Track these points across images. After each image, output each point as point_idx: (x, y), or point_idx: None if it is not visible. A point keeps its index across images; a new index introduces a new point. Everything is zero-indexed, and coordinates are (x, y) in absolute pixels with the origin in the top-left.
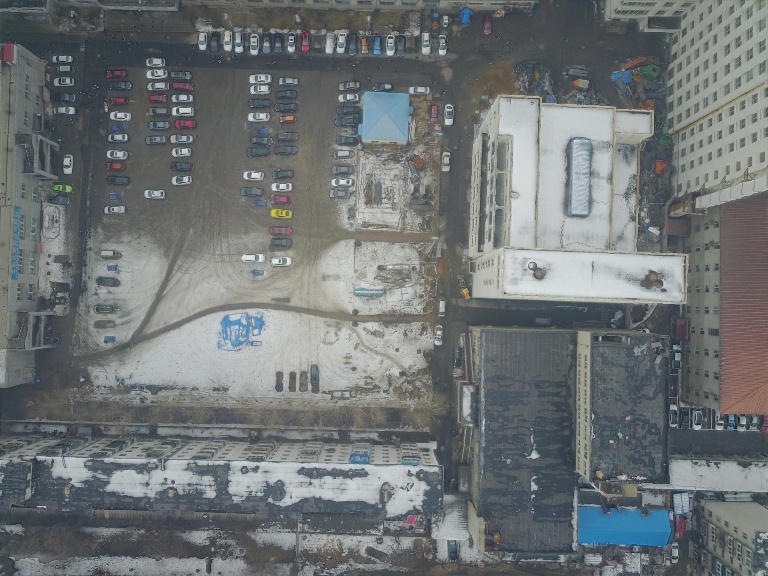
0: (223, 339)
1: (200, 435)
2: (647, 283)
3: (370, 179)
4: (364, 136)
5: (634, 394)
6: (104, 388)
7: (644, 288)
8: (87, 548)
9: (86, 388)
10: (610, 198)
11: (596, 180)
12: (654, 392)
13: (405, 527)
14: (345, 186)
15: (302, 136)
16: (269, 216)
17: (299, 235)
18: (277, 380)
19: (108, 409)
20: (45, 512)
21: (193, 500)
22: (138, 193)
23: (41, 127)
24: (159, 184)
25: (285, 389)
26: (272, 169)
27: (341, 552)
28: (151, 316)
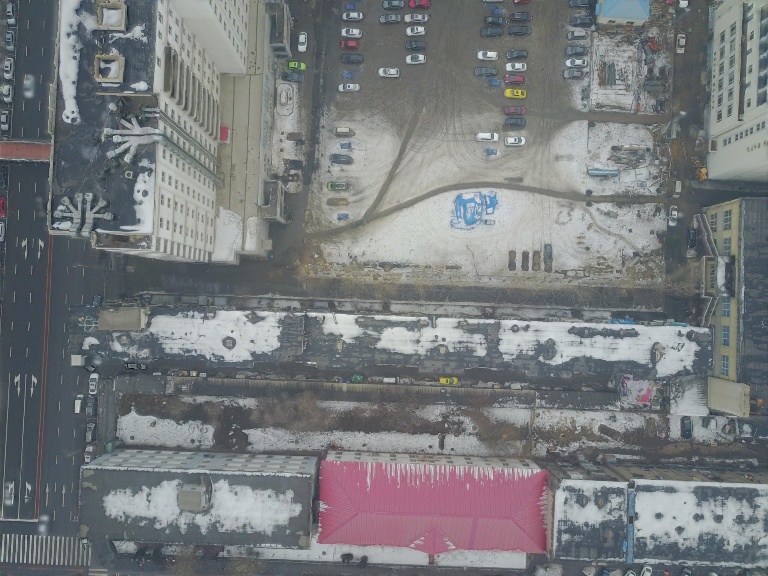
0: (456, 217)
1: (433, 312)
2: None
3: (604, 60)
4: (606, 14)
5: None
6: (337, 265)
7: None
8: (320, 423)
9: (320, 264)
10: None
11: None
12: None
13: (639, 405)
14: (580, 67)
15: (535, 17)
16: (502, 96)
17: (532, 115)
18: (510, 259)
19: (341, 286)
20: (283, 384)
21: (463, 358)
22: (371, 72)
23: (282, 1)
24: (392, 63)
25: (518, 268)
26: (505, 50)
27: (574, 430)
28: (384, 194)
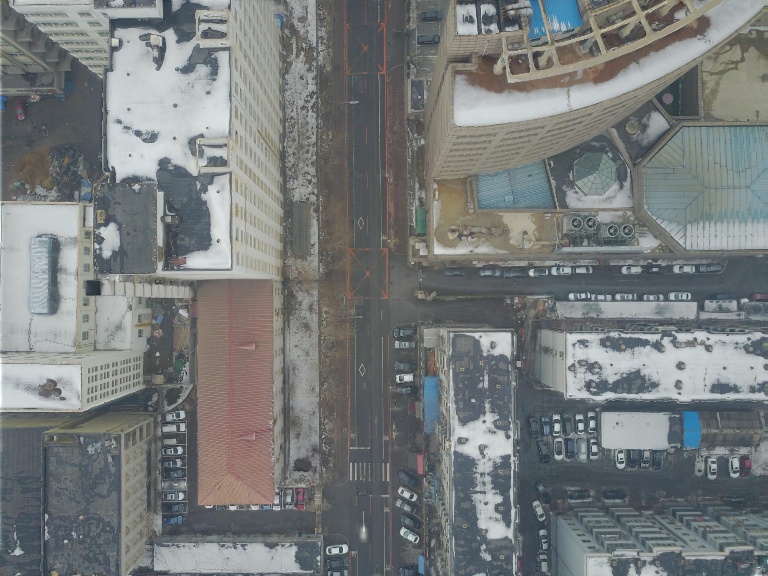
0: None
1: None
2: (46, 392)
3: None
4: None
5: (88, 493)
6: None
7: (42, 397)
8: None
9: None
10: (76, 294)
11: (63, 276)
12: (108, 490)
13: None
14: None
15: None
16: None
17: None
18: None
19: None
20: None
21: None
22: None
23: None
24: None
25: None
26: None
27: None
28: None
